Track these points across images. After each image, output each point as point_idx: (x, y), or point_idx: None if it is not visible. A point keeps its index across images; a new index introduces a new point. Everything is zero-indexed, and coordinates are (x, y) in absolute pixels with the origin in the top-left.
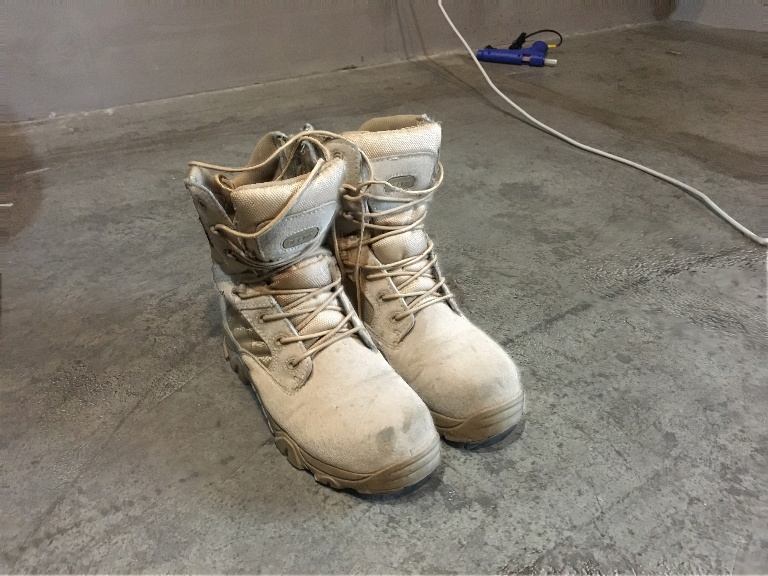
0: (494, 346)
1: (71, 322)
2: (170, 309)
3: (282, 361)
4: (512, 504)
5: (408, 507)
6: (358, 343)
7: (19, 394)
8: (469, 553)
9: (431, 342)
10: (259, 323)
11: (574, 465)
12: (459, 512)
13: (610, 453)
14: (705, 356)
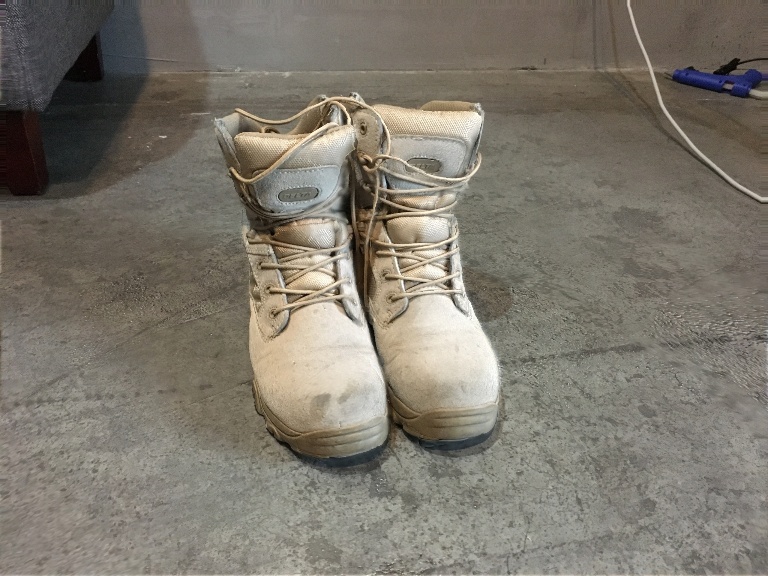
0: (483, 352)
1: (154, 240)
2: (236, 249)
3: (267, 309)
4: (434, 510)
5: (334, 478)
6: (339, 310)
7: (83, 287)
8: (364, 539)
9: (416, 330)
10: (257, 269)
11: (522, 496)
12: (378, 499)
13: (569, 498)
14: (748, 436)
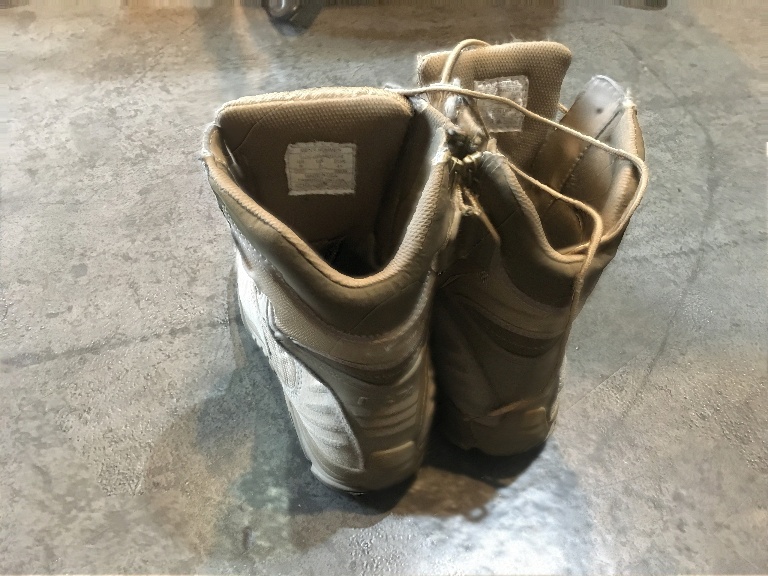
0: None
1: None
2: (656, 573)
3: None
4: None
5: None
6: None
7: None
8: None
9: None
10: None
11: None
12: None
13: (208, 193)
14: None
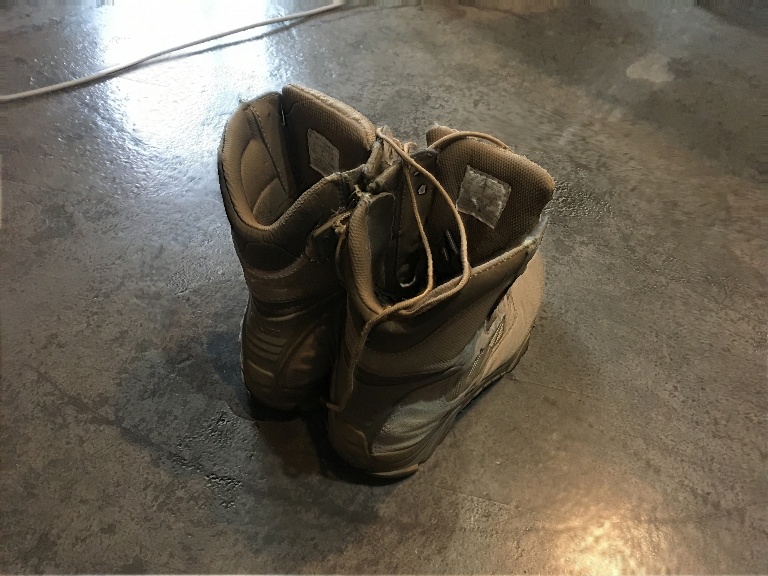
0: None
1: None
2: None
3: None
4: None
5: None
6: None
7: None
8: None
9: None
10: None
11: None
12: None
13: None
14: None
